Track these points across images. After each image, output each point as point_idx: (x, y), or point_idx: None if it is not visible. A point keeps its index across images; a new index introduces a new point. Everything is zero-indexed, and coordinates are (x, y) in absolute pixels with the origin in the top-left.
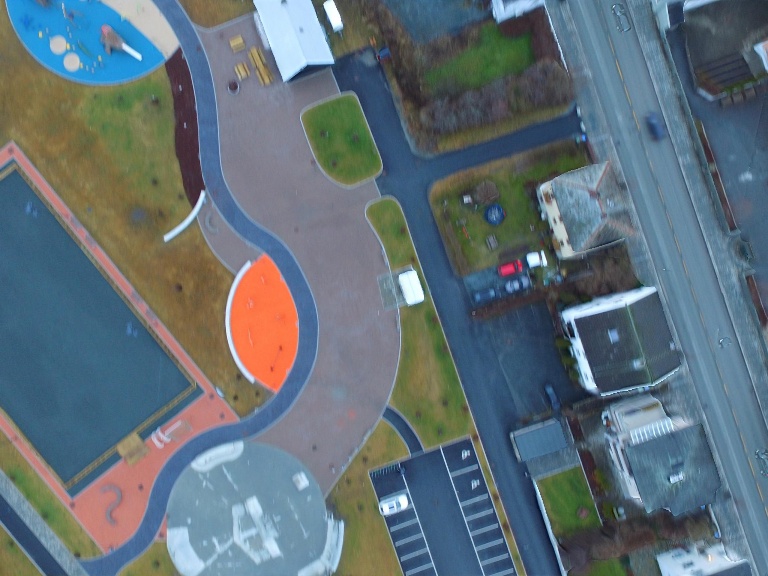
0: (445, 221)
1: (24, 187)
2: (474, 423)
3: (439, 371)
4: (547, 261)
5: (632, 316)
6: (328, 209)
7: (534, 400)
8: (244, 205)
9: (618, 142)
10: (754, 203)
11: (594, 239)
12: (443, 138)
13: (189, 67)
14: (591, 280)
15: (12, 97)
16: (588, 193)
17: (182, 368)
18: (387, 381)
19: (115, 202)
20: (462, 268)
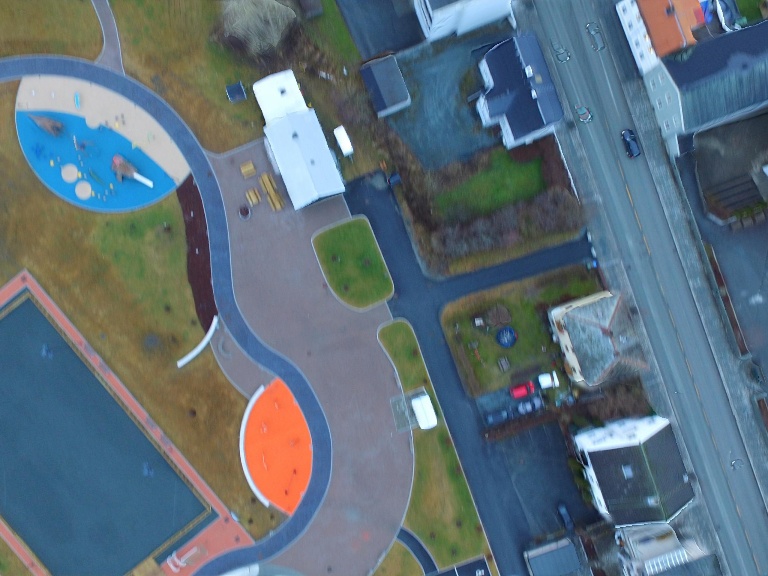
0: (457, 343)
1: (37, 315)
2: (488, 543)
3: (453, 493)
4: (559, 382)
5: (646, 454)
6: (340, 332)
7: (547, 519)
8: (257, 329)
9: (629, 266)
10: (765, 325)
11: (607, 374)
12: (454, 261)
13: (200, 193)
14: (603, 405)
15: (24, 226)
16: (601, 331)
17: (197, 493)
18: (401, 502)
19: (128, 329)
20: (474, 390)
